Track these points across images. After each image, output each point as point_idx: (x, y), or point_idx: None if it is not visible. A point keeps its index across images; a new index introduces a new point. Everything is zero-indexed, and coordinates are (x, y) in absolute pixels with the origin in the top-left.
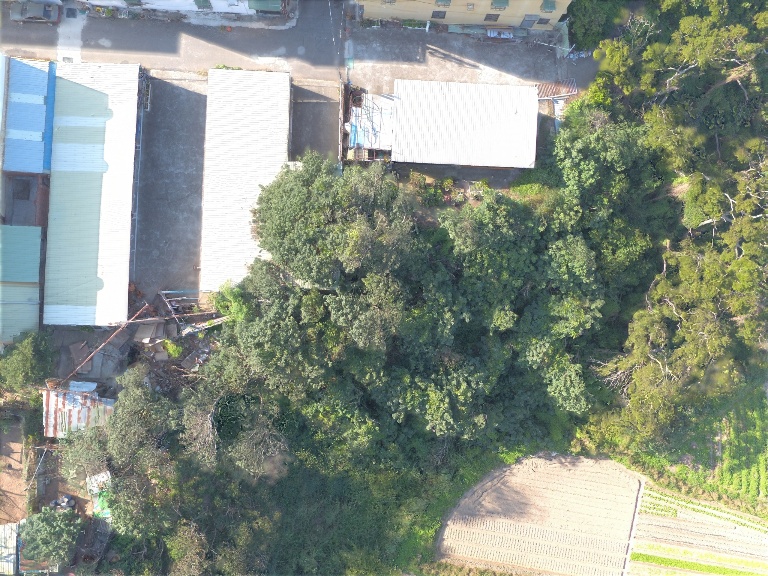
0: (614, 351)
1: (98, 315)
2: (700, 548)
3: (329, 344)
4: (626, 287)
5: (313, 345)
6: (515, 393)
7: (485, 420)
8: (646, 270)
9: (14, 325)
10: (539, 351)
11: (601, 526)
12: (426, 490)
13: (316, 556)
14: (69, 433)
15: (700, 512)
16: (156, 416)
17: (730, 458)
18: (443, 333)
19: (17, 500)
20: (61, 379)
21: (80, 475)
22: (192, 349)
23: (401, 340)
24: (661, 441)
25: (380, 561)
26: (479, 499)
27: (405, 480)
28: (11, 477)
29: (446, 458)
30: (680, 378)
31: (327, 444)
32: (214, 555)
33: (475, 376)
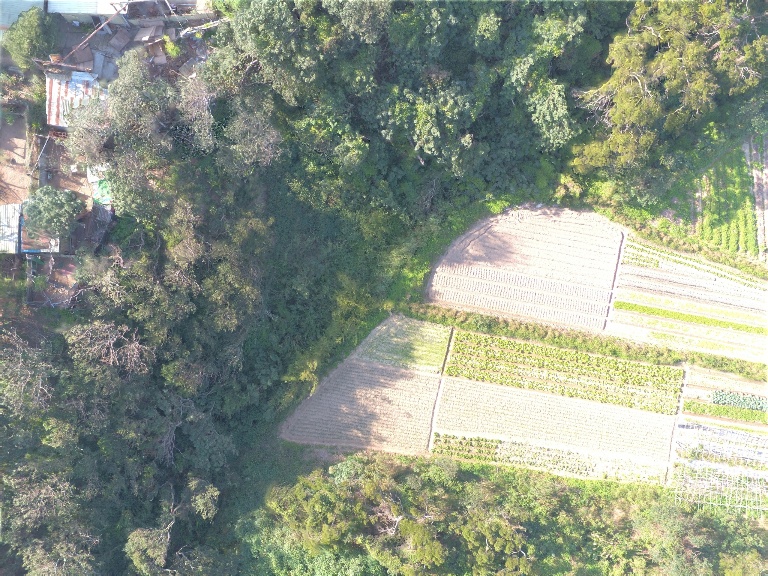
0: (596, 86)
1: (100, 4)
2: (681, 298)
3: (321, 36)
4: (608, 27)
5: (305, 34)
6: (501, 135)
7: (471, 139)
8: (626, 4)
9: (20, 12)
10: (523, 68)
11: (585, 276)
12: (415, 235)
13: (308, 287)
14: (71, 108)
15: (681, 263)
16: (154, 92)
17: (710, 213)
18: (430, 41)
19: (20, 193)
20: (64, 71)
21: (81, 172)
22: (190, 56)
23: (390, 58)
24: (642, 186)
25: (370, 296)
26: (467, 248)
27: (395, 227)
28: (15, 171)
29: (435, 207)
30: (659, 97)
31: (319, 178)
32: (209, 247)
33: (462, 96)
